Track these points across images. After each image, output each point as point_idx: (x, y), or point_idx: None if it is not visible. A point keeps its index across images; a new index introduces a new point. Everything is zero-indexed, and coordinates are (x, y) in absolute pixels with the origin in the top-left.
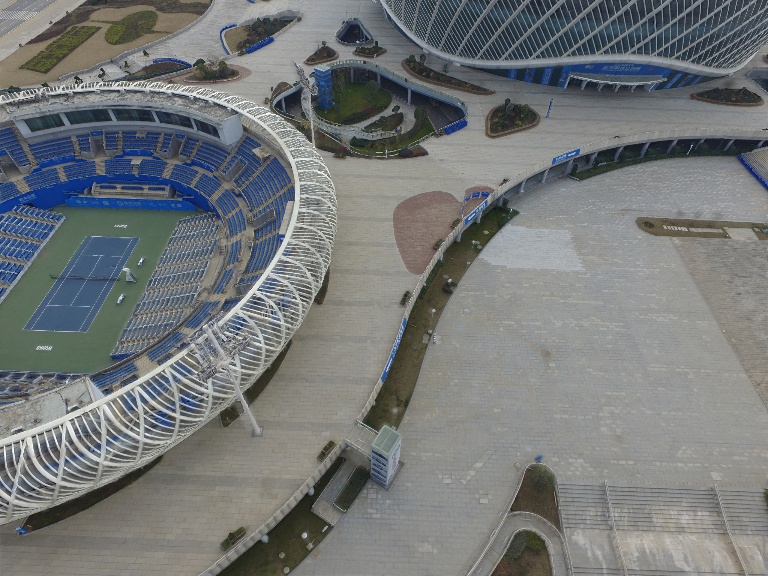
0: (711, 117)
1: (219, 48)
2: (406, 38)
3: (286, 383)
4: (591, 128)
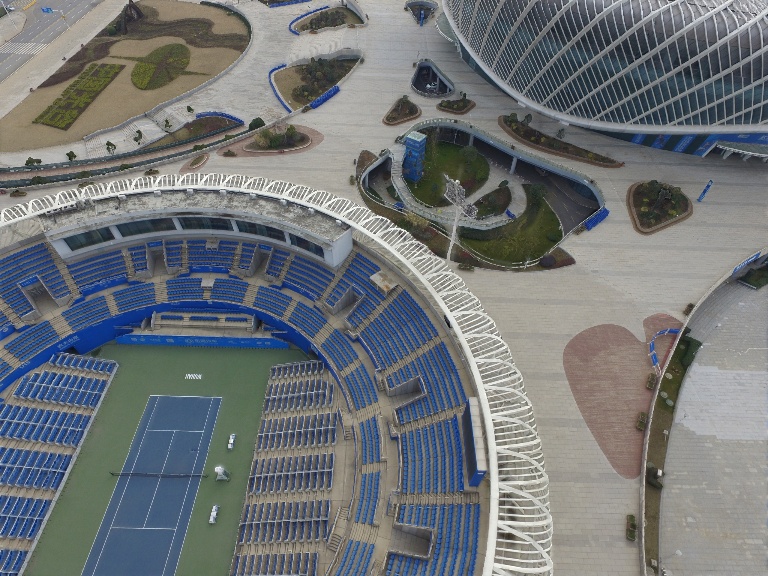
0: None
1: (271, 96)
2: (493, 86)
3: None
4: (758, 217)
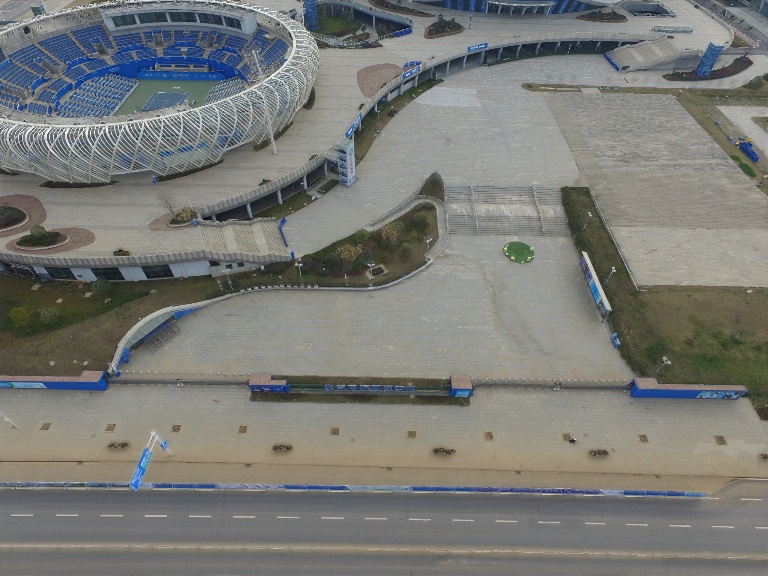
0: (586, 28)
1: None
2: None
3: (290, 137)
4: (499, 34)
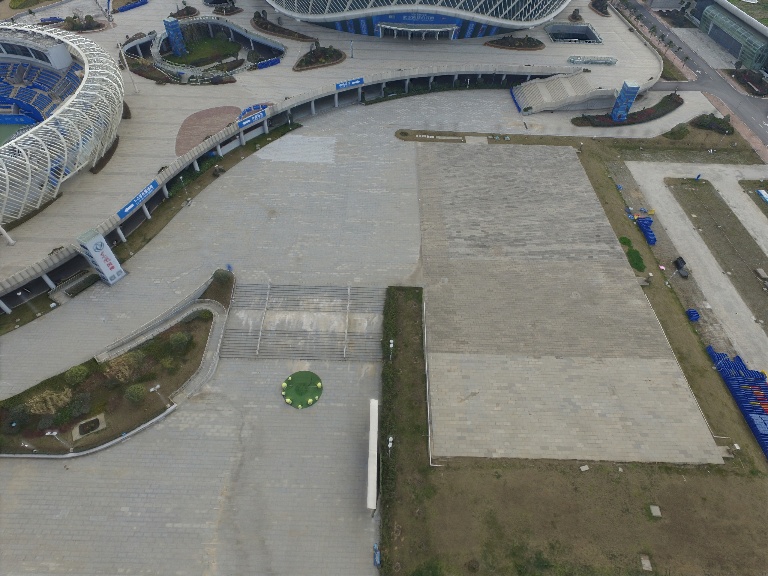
0: (491, 58)
1: None
2: (265, 1)
3: (46, 217)
4: (384, 65)
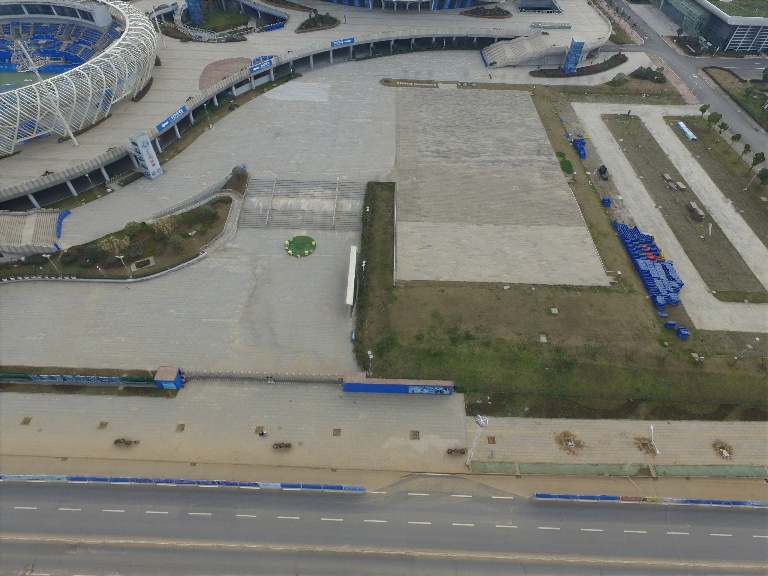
0: (464, 24)
1: None
2: None
3: (101, 129)
4: (372, 29)
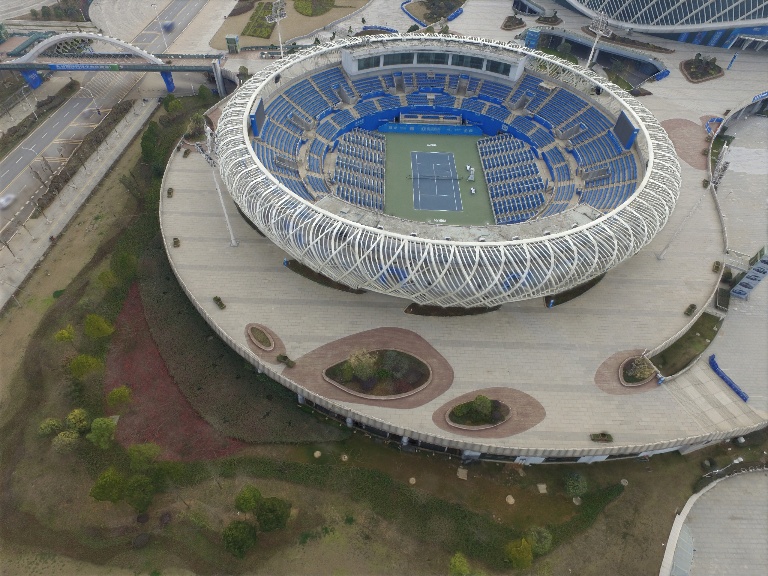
0: None
1: (409, 19)
2: (571, 11)
3: None
4: (767, 77)
